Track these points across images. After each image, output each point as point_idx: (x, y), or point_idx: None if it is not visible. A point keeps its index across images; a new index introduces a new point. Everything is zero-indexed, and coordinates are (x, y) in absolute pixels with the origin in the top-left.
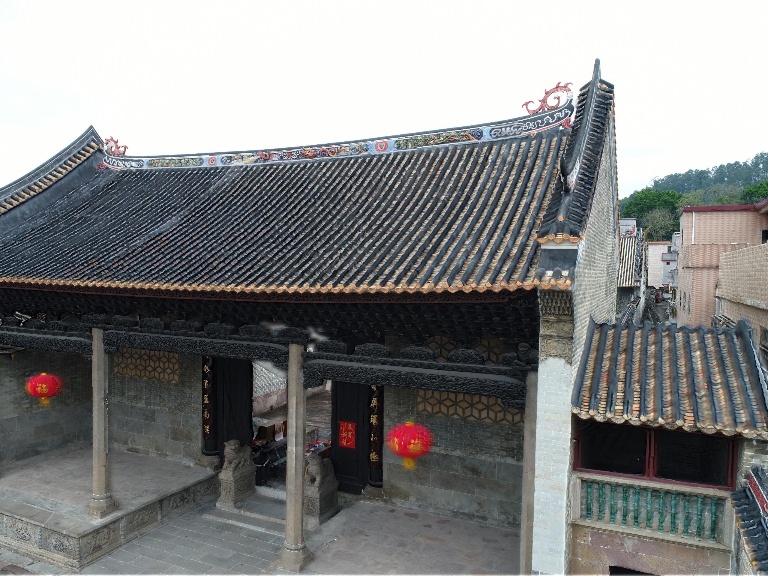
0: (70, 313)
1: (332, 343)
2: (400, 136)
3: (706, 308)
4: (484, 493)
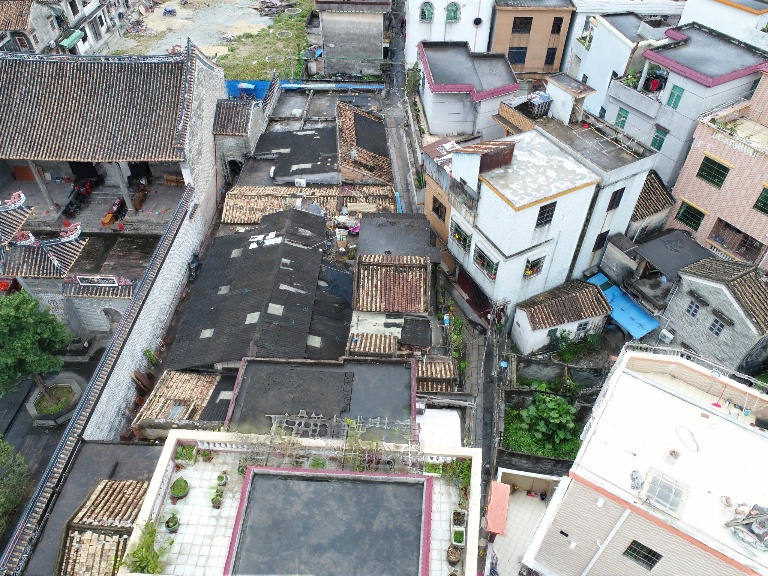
0: None
1: None
2: None
3: None
4: None
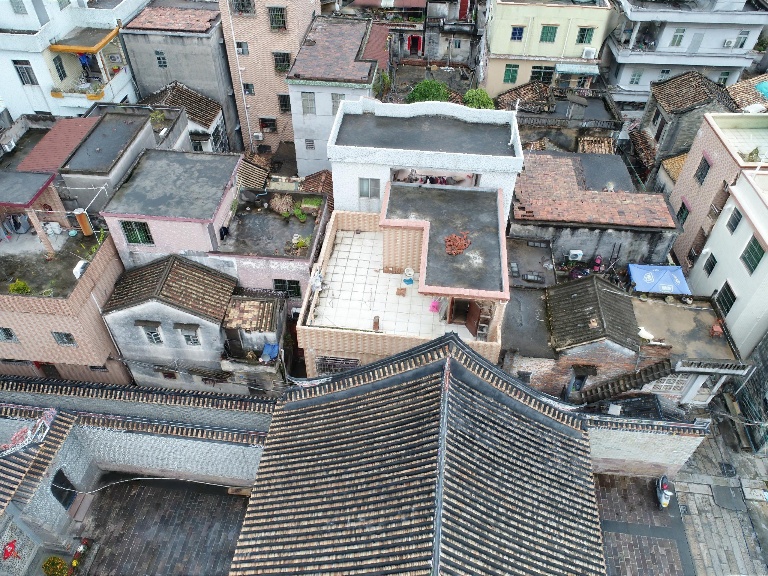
0: None
1: None
2: None
3: (96, 333)
4: None
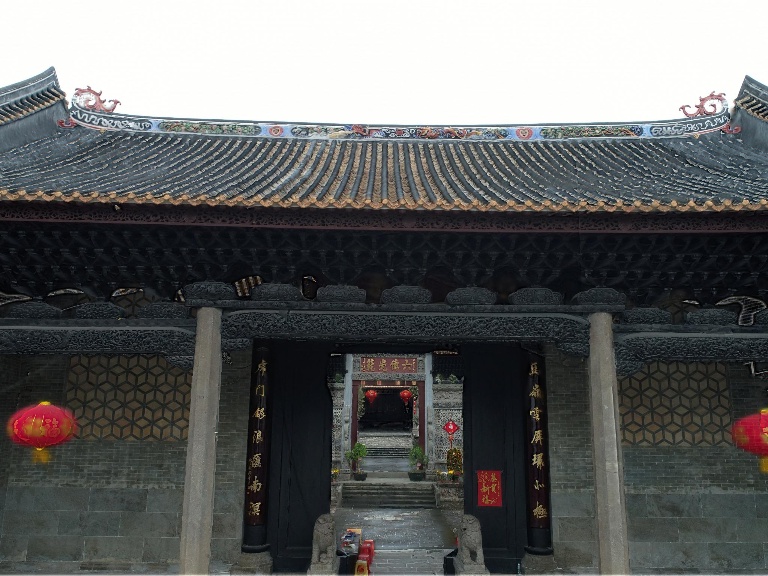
0: (147, 285)
1: (653, 311)
2: (546, 125)
3: None
4: (690, 537)
